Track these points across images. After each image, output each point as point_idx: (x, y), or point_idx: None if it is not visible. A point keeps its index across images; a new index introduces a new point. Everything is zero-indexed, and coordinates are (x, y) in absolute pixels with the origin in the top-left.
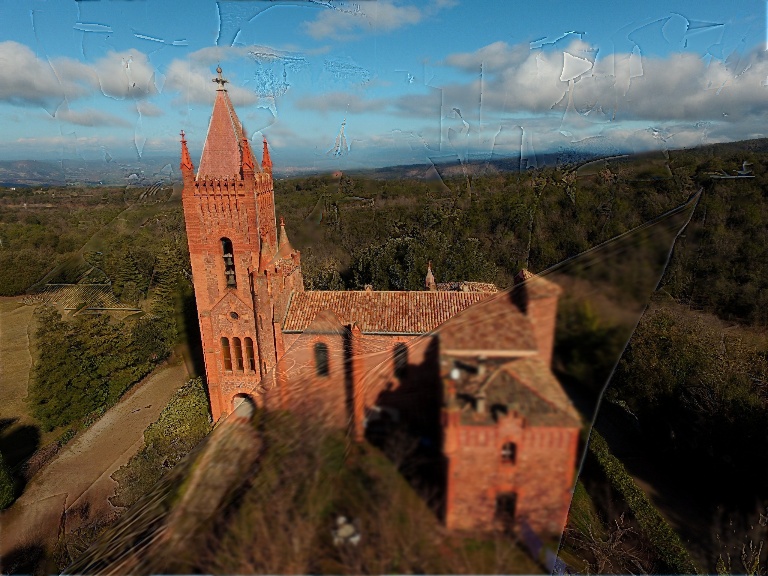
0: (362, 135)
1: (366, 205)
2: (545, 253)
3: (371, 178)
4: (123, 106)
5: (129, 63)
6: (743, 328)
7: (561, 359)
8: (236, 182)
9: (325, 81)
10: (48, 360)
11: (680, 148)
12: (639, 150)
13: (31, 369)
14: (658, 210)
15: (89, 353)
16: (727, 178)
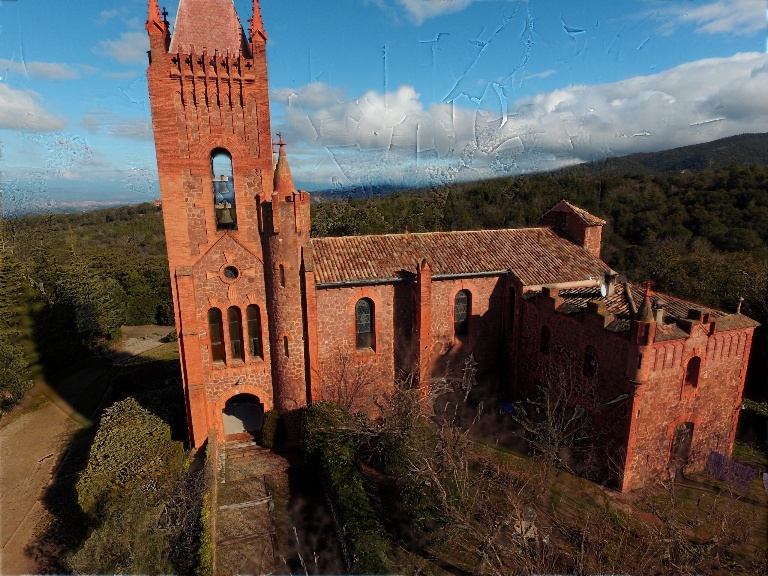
0: None
1: None
2: None
3: None
4: None
5: None
6: None
7: None
8: (242, 59)
9: None
10: None
11: None
12: (547, 130)
13: None
14: (561, 188)
15: None
16: None
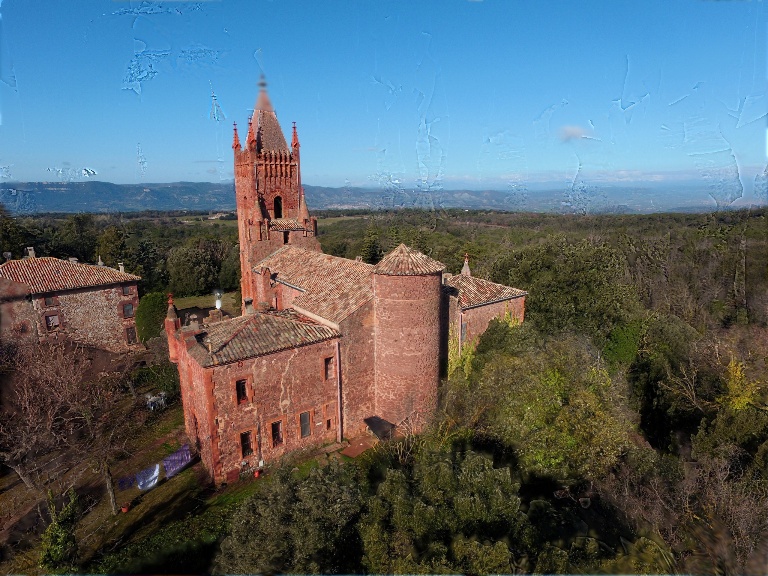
0: (255, 106)
1: (577, 212)
2: None
3: (615, 184)
4: (439, 130)
5: (396, 91)
6: None
7: None
8: (246, 155)
9: (182, 65)
10: None
11: None
12: None
13: None
14: None
15: None
16: None
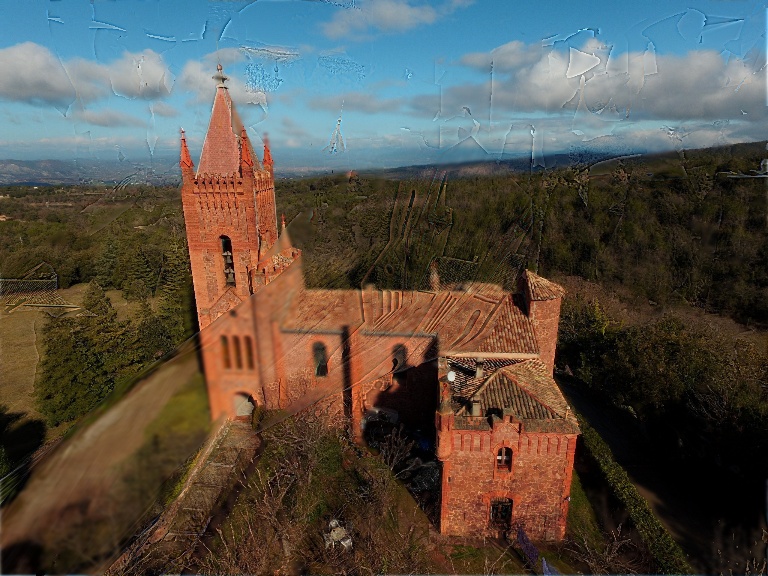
0: (360, 132)
1: None
2: (555, 254)
3: (380, 177)
4: (137, 106)
5: (140, 63)
6: (760, 333)
7: (167, 385)
8: (235, 180)
9: (319, 77)
10: (54, 356)
11: (696, 147)
12: (652, 149)
13: (38, 364)
14: (672, 211)
15: (95, 349)
16: (745, 178)
